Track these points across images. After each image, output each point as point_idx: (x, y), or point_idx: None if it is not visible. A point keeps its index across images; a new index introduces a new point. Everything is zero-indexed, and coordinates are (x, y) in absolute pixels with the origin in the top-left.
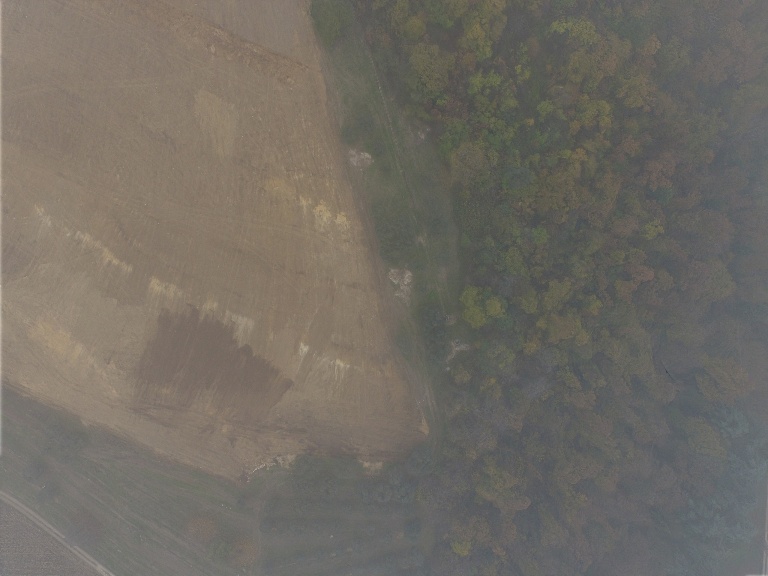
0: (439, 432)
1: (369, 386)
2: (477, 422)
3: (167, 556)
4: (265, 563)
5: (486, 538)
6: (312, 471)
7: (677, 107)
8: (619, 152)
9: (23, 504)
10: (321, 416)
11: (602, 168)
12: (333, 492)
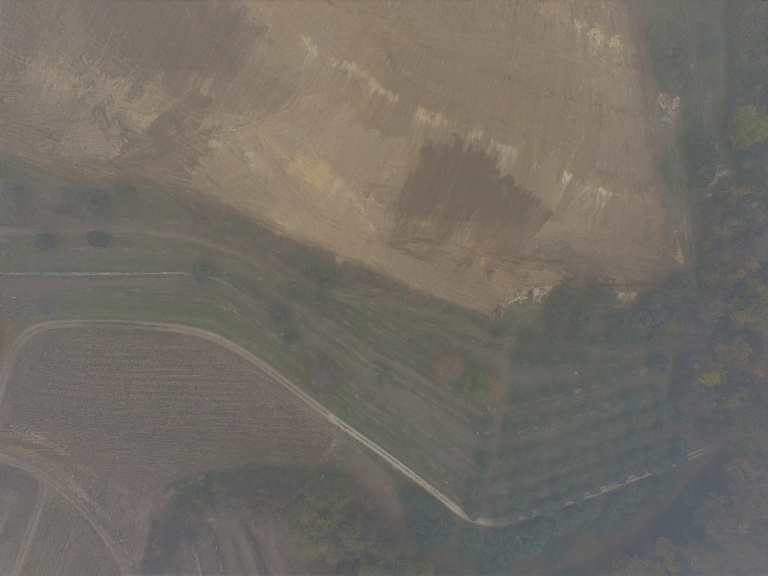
0: (692, 262)
1: (630, 214)
2: (750, 239)
3: (409, 397)
4: (509, 400)
5: (745, 360)
6: (574, 298)
7: None
8: None
9: (254, 355)
10: (579, 246)
11: None
12: (592, 320)
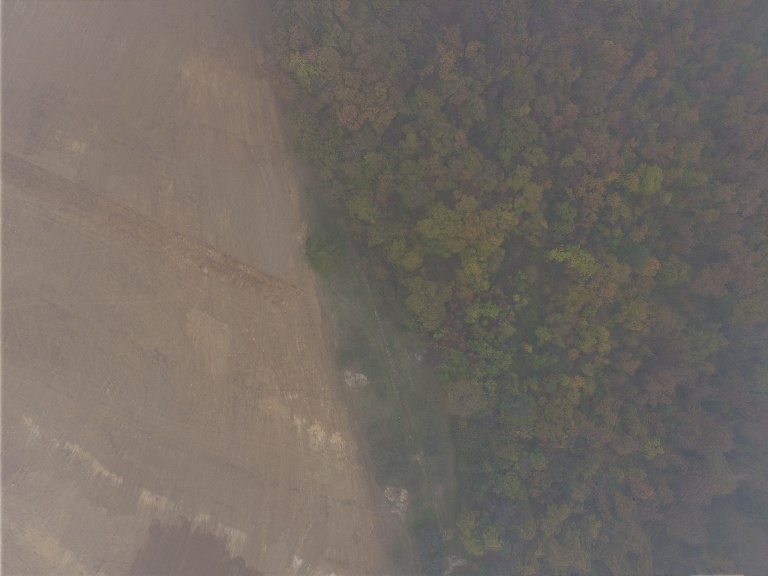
0: None
1: None
2: None
3: None
4: None
5: None
6: None
7: (677, 322)
8: (618, 370)
9: None
10: None
11: (601, 386)
12: None
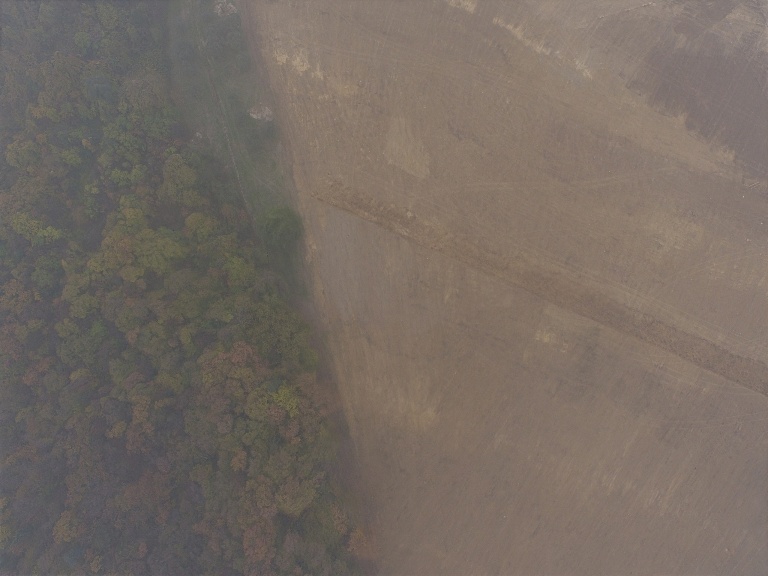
0: None
1: None
2: None
3: None
4: None
5: None
6: None
7: None
8: (5, 130)
9: None
10: None
11: (22, 115)
12: None
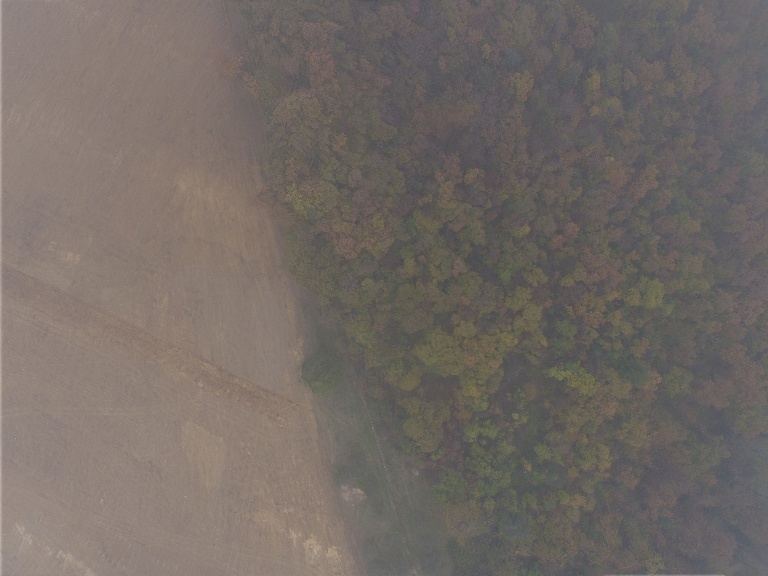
0: None
1: None
2: None
3: None
4: None
5: None
6: None
7: (678, 434)
8: (619, 483)
9: None
10: None
11: (601, 499)
12: None
